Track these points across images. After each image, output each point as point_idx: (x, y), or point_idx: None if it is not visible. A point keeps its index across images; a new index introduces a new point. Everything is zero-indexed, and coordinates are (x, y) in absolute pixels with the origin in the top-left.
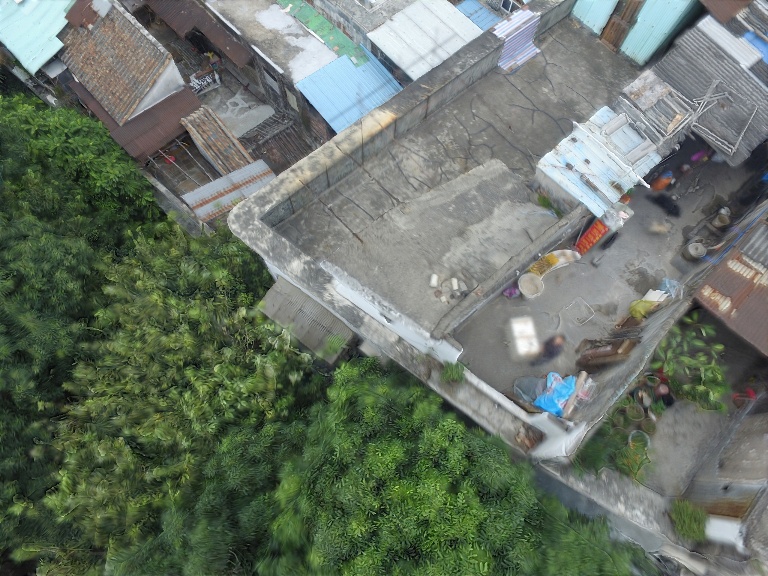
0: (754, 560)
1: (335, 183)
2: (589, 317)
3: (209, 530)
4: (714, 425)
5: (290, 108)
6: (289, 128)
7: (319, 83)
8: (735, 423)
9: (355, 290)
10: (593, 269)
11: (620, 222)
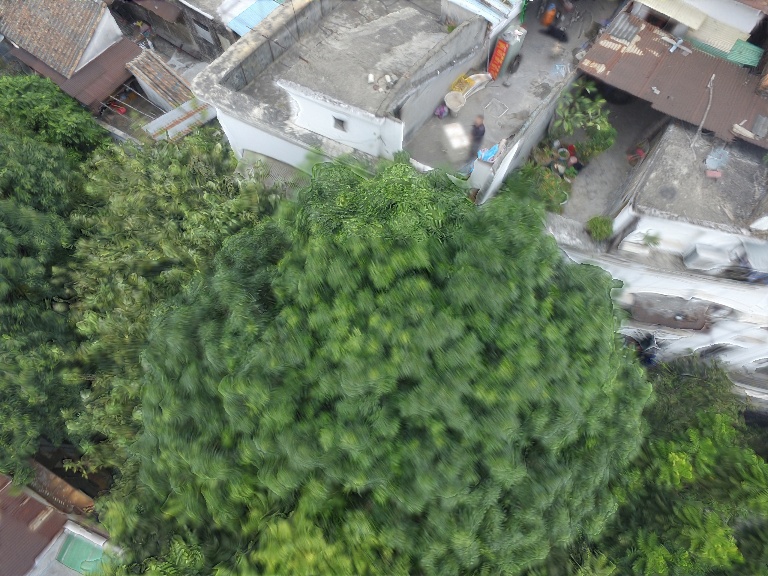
0: (654, 249)
1: (278, 57)
2: (504, 111)
3: (225, 281)
4: (617, 182)
5: None
6: None
7: (249, 21)
8: (632, 175)
9: (309, 95)
10: (505, 89)
11: (517, 38)
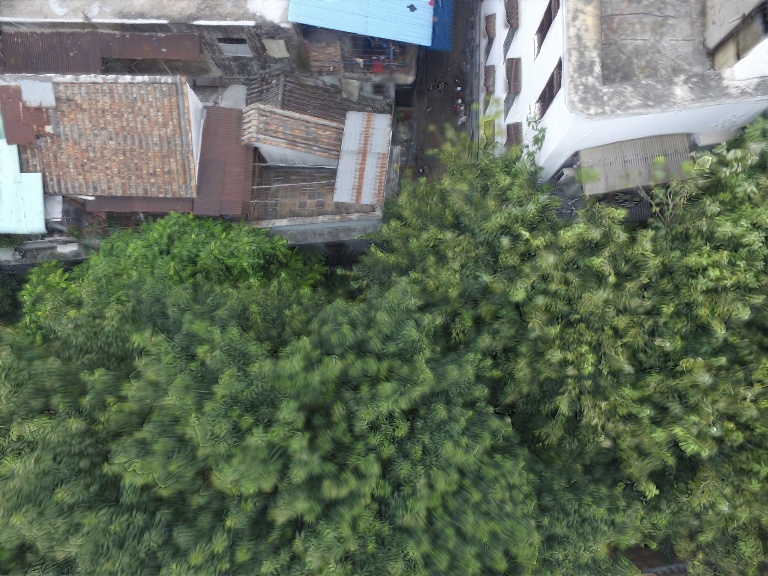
0: None
1: None
2: None
3: None
4: None
5: (273, 62)
6: (286, 84)
7: (305, 1)
8: None
9: None
10: None
11: None
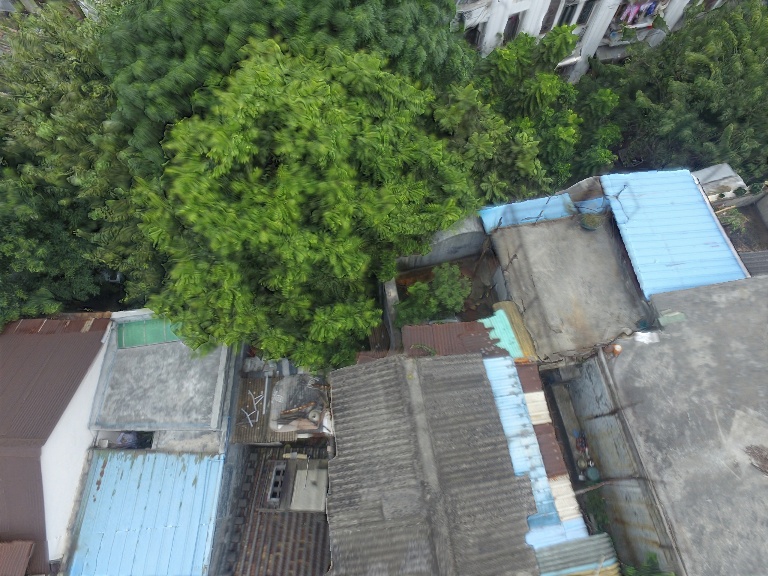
0: None
1: None
2: None
3: None
4: None
5: None
6: None
7: None
8: None
9: None
10: None
11: None
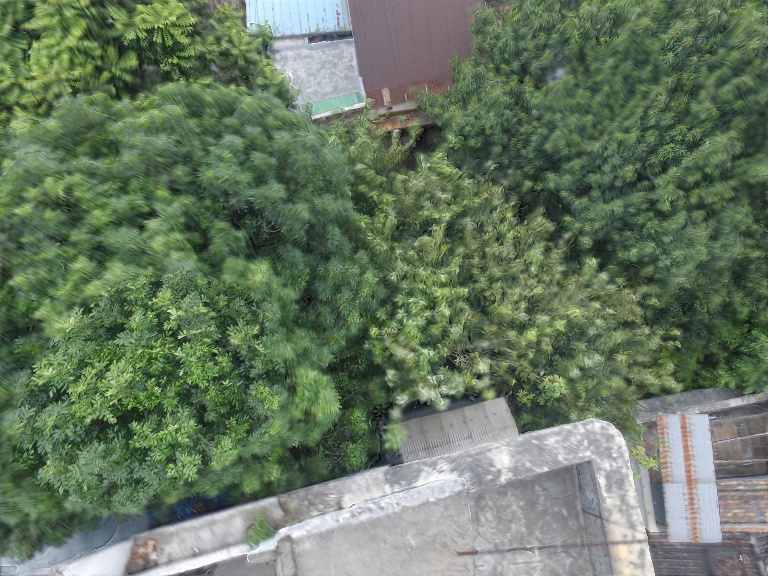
0: None
1: None
2: None
3: (306, 224)
4: None
5: None
6: None
7: None
8: None
9: (405, 494)
10: None
11: None
